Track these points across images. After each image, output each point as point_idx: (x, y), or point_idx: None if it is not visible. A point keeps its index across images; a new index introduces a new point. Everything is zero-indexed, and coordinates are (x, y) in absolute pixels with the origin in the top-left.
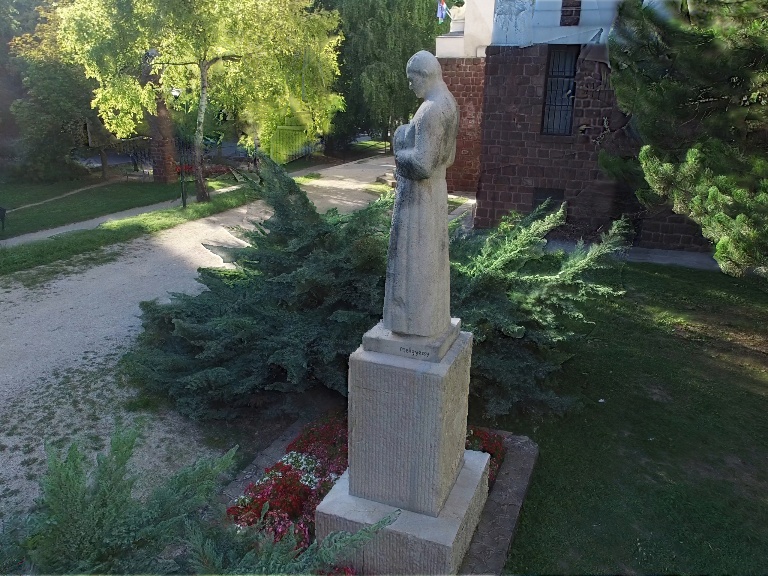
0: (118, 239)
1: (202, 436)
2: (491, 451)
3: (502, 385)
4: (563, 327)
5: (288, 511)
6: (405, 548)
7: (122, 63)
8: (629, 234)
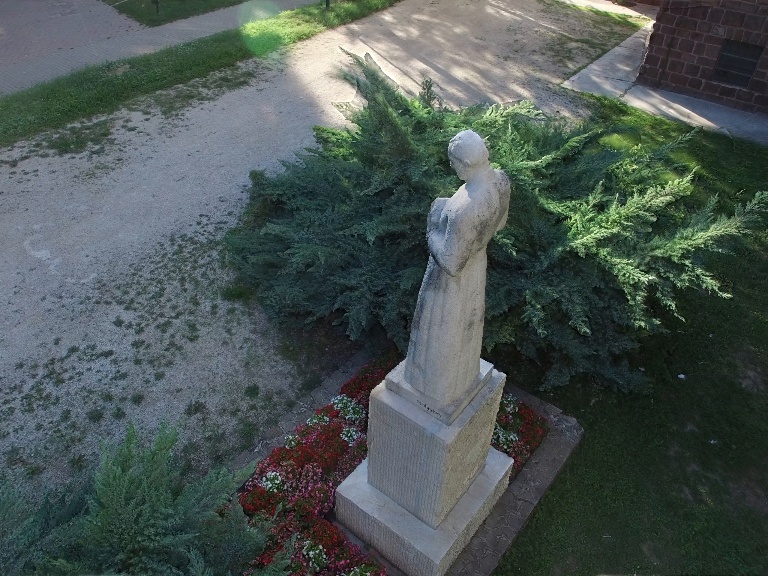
0: (254, 52)
1: (280, 343)
2: (527, 438)
3: (568, 355)
4: (652, 310)
5: (322, 466)
6: (402, 546)
7: None
8: None
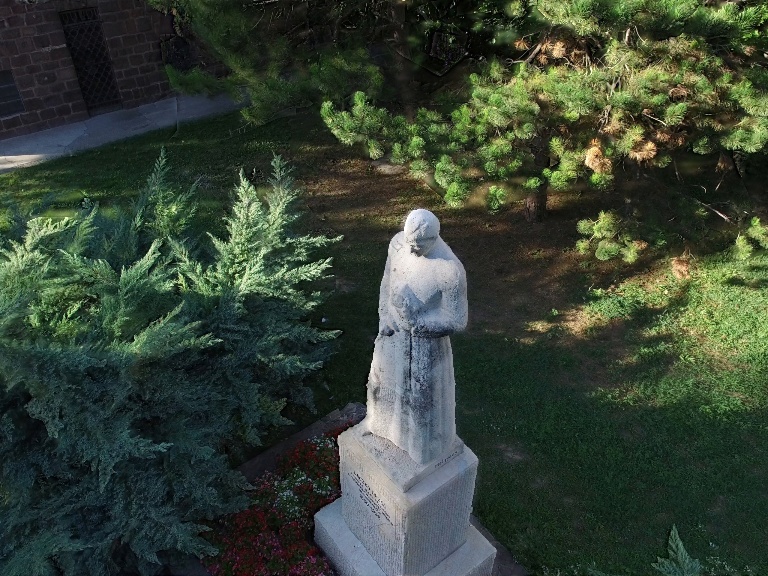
0: None
1: None
2: None
3: None
4: None
5: None
6: None
7: None
8: (294, 172)
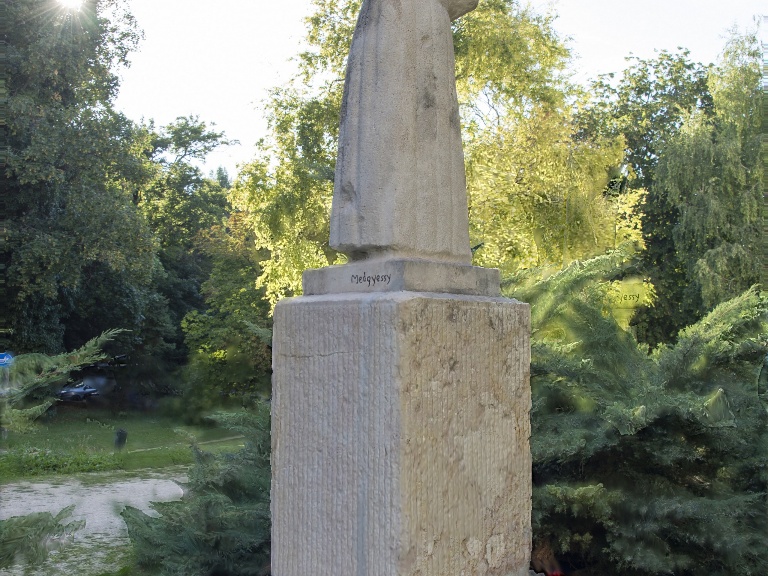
0: None
1: None
2: None
3: (729, 561)
4: None
5: None
6: None
7: (301, 223)
8: None
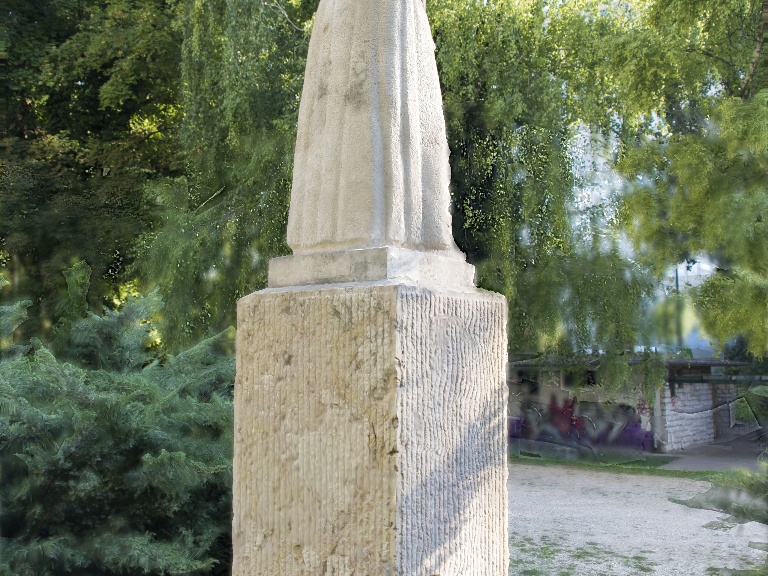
0: None
1: None
2: None
3: None
4: None
5: None
6: None
7: None
8: None
